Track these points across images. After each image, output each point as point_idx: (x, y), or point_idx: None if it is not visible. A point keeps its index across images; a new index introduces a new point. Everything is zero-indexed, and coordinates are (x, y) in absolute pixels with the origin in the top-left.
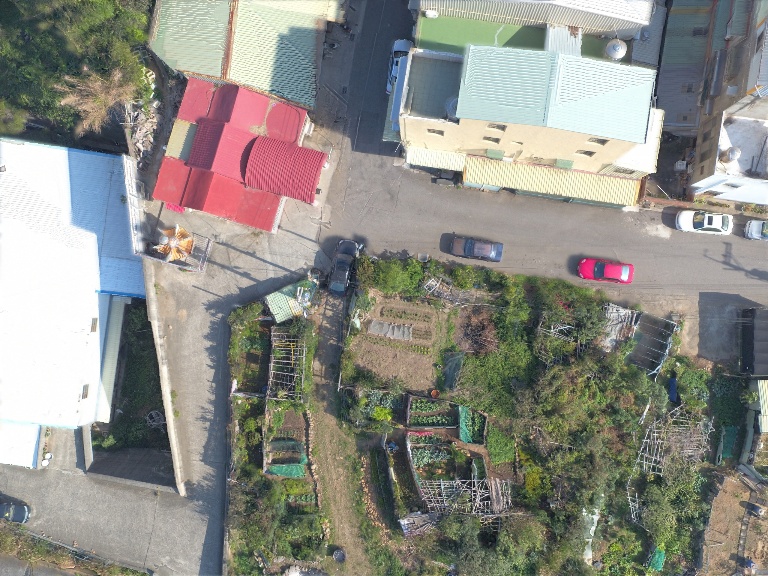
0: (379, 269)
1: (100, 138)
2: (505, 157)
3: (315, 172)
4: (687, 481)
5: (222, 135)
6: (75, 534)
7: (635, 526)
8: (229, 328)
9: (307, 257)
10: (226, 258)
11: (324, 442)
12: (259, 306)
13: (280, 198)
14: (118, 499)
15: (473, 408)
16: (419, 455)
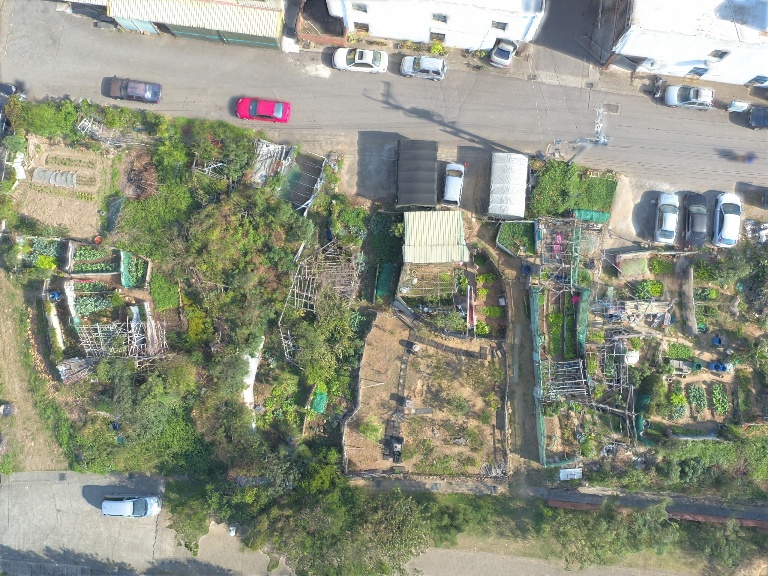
0: (28, 108)
1: None
2: None
3: None
4: (340, 317)
5: None
6: None
7: (296, 368)
8: None
9: None
10: None
11: None
12: None
13: None
14: None
15: (134, 252)
16: (82, 302)
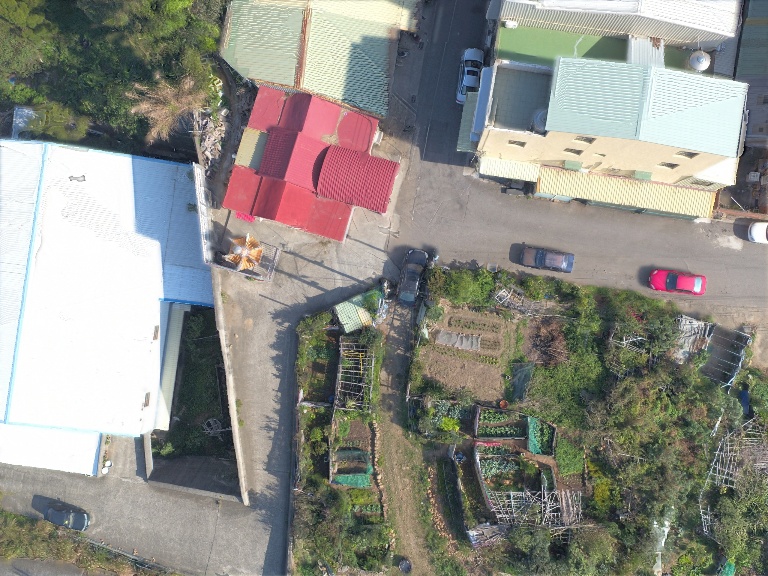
0: (450, 279)
1: (159, 144)
2: (581, 168)
3: (389, 182)
4: (759, 494)
5: (295, 144)
6: (135, 542)
7: (705, 538)
8: (296, 337)
9: (375, 267)
10: (293, 267)
11: (390, 452)
12: (328, 316)
13: (351, 208)
14: (179, 507)
15: (542, 419)
16: (487, 466)
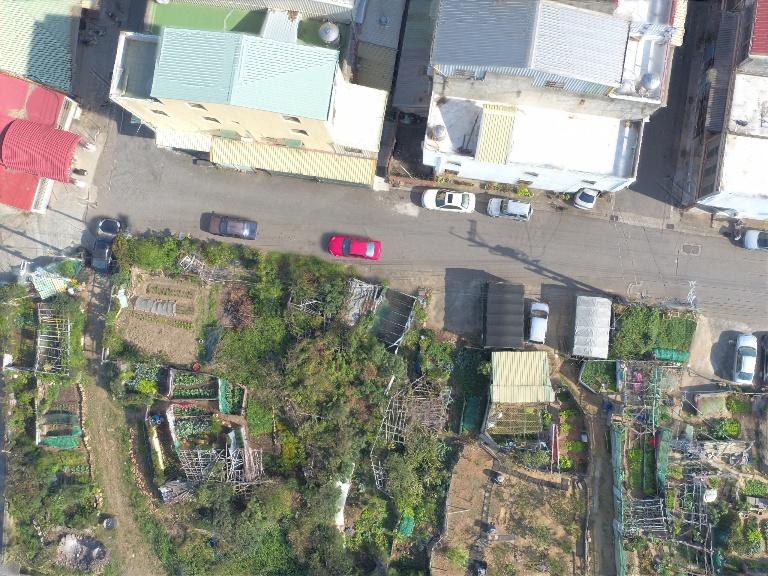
0: (134, 246)
1: None
2: (244, 138)
3: (66, 153)
4: (428, 449)
5: None
6: None
7: (384, 494)
8: None
9: (74, 236)
10: None
11: (96, 415)
12: (24, 283)
13: (39, 179)
14: None
15: (231, 381)
16: (182, 426)
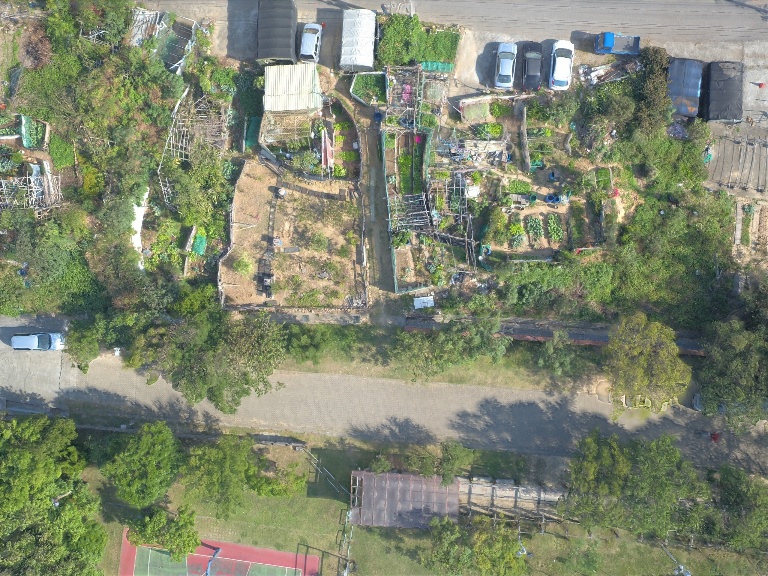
0: None
1: None
2: None
3: None
4: (212, 165)
5: None
6: None
7: (177, 214)
8: None
9: None
10: None
11: None
12: None
13: None
14: None
15: (33, 117)
16: None
